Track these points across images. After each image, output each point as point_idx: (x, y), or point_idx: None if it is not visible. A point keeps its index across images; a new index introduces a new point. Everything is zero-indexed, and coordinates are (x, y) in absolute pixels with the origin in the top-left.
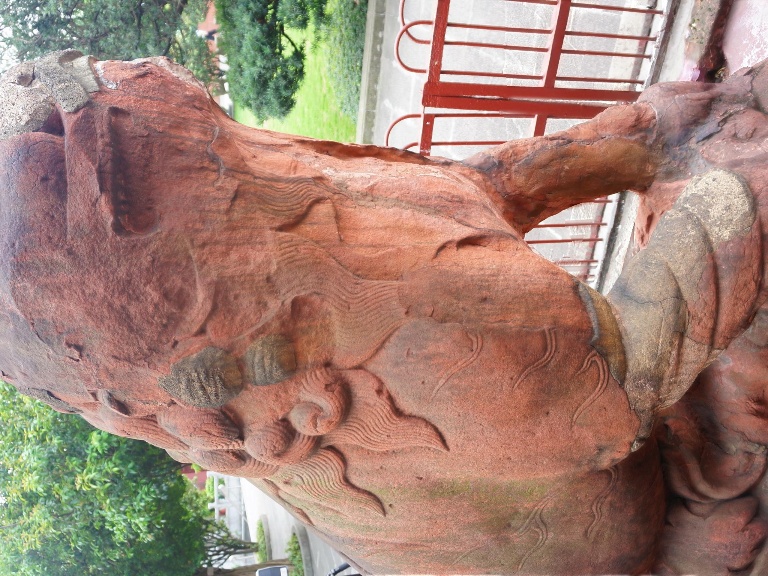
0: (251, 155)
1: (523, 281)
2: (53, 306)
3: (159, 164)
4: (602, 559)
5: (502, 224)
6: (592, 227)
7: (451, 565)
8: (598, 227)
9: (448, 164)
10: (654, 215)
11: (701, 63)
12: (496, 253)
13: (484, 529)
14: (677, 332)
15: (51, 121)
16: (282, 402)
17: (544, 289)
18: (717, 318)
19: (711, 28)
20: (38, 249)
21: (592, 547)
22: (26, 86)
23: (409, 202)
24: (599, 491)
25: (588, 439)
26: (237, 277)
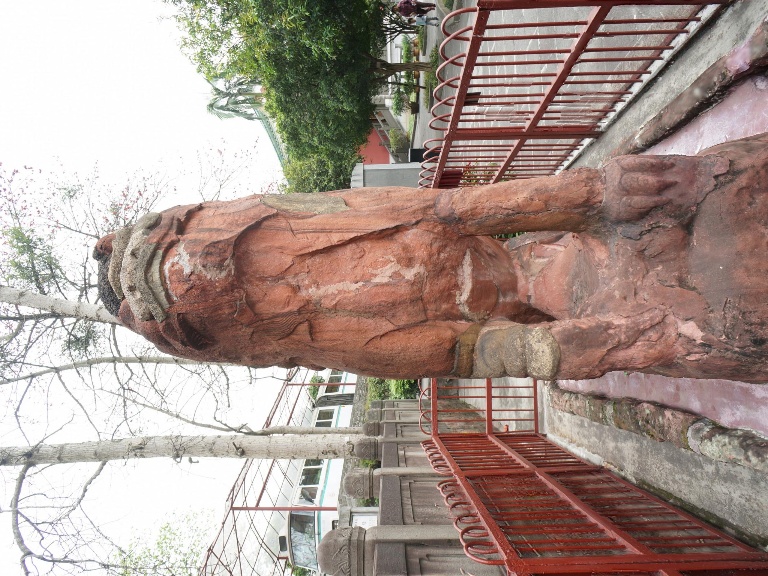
0: (263, 295)
1: (414, 356)
2: None
3: None
4: None
5: (419, 313)
6: (634, 75)
7: None
8: (640, 75)
9: (417, 223)
10: None
11: (755, 62)
12: (405, 337)
13: None
14: None
15: (152, 315)
16: None
17: (426, 359)
18: None
19: None
20: (169, 353)
21: None
22: (134, 289)
23: (357, 312)
24: None
25: None
26: None
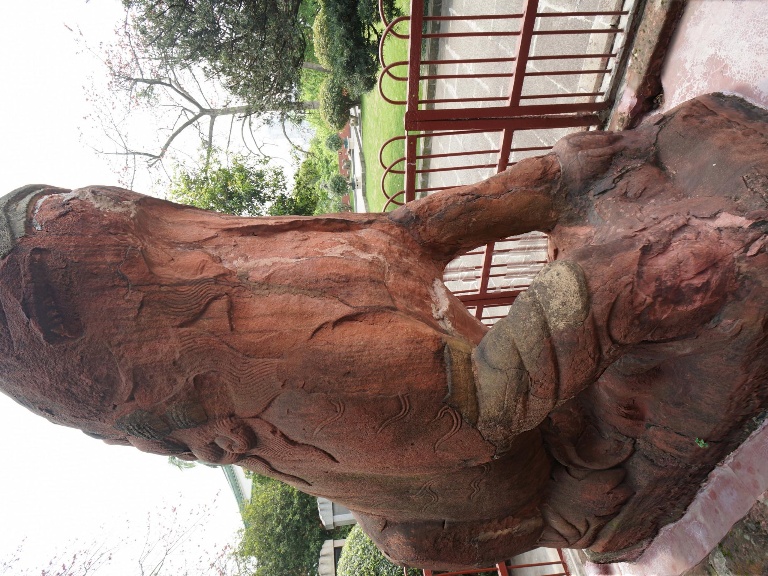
0: (169, 259)
1: (385, 355)
2: (20, 389)
3: (78, 287)
4: (487, 509)
5: (384, 296)
6: None
7: (372, 507)
8: None
9: (370, 222)
10: (558, 250)
11: (639, 92)
12: (369, 328)
13: (388, 494)
14: (521, 392)
15: None
16: (205, 436)
17: (403, 361)
18: (559, 381)
19: (649, 60)
20: None
21: (476, 504)
22: None
23: (299, 287)
24: (474, 477)
25: (451, 457)
26: (149, 364)
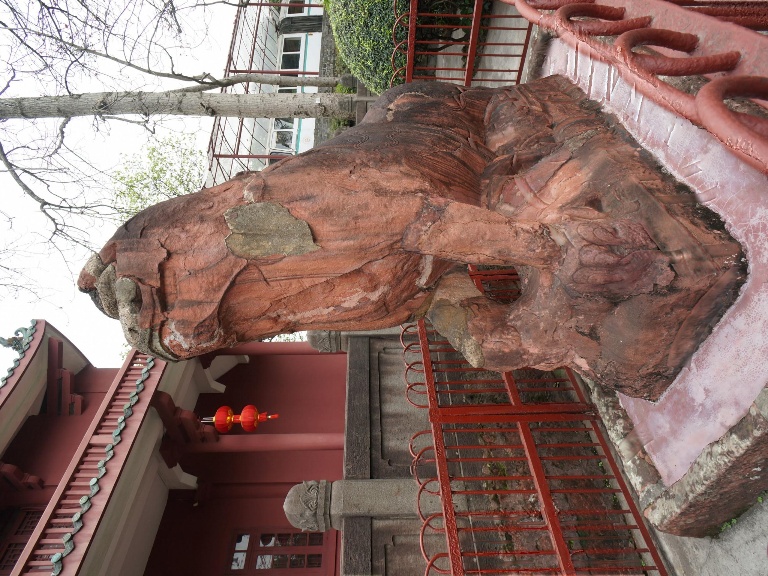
0: None
1: None
2: None
3: None
4: None
5: None
6: None
7: None
8: None
9: None
10: None
11: None
12: None
13: None
14: None
15: None
16: None
17: None
18: None
19: None
20: None
21: None
22: None
23: None
24: None
25: None
26: None
